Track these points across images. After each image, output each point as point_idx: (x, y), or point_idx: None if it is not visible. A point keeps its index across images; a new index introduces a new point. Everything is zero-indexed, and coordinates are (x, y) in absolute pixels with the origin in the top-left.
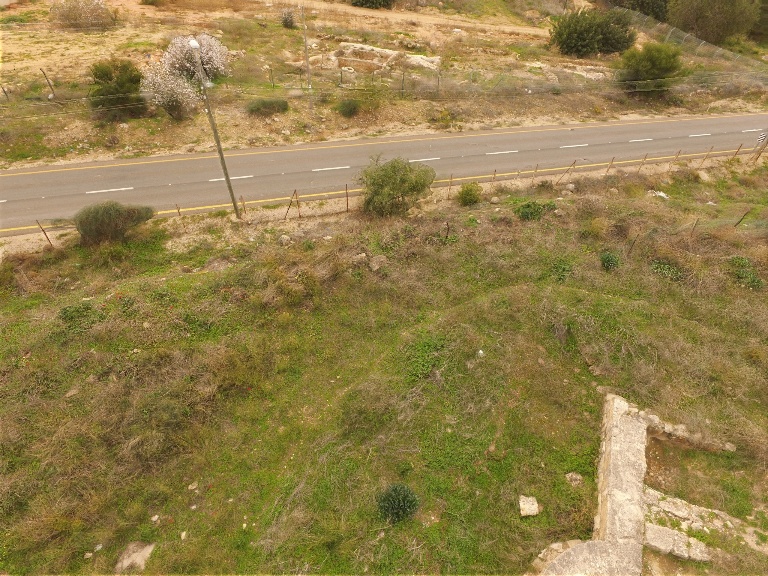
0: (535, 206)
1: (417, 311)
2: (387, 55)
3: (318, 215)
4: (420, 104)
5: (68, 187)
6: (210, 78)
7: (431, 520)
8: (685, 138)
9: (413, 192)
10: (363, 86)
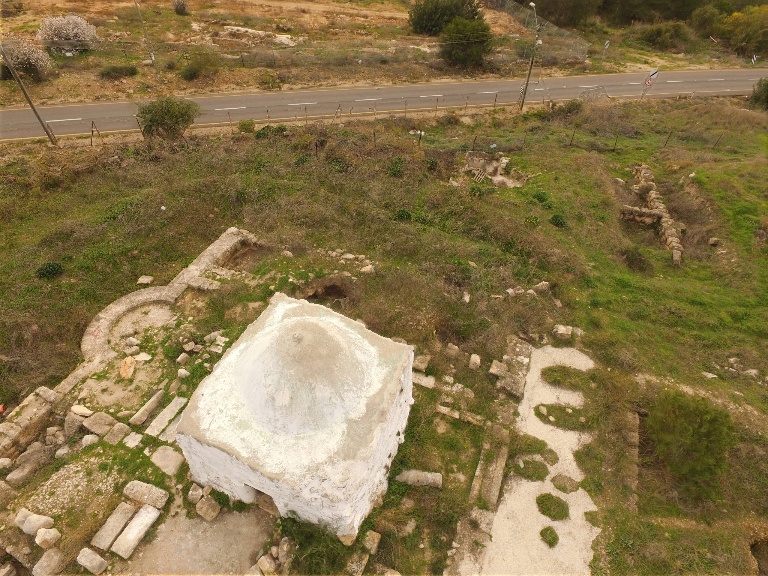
0: (268, 129)
1: None
2: None
3: (120, 143)
4: (256, 70)
5: None
6: (79, 51)
7: (70, 280)
8: (472, 94)
9: (173, 118)
10: (197, 54)
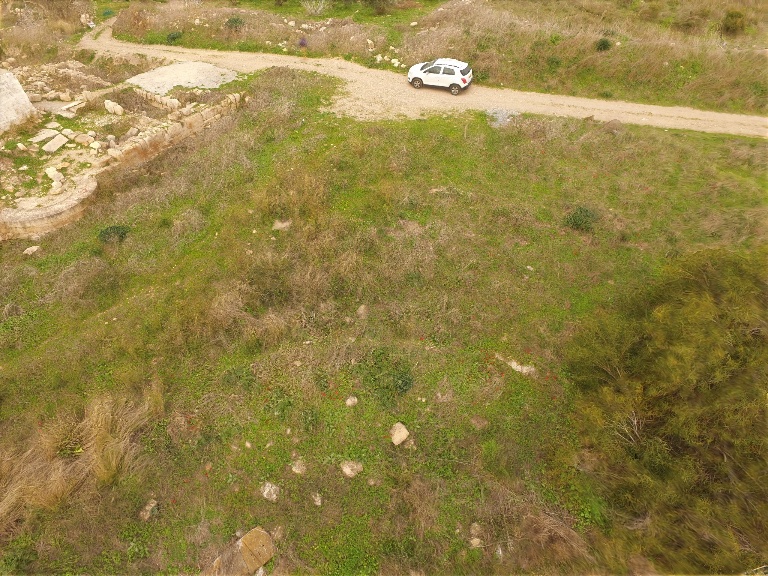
0: None
1: None
2: None
3: None
4: None
5: None
6: None
7: None
8: None
9: None
10: None
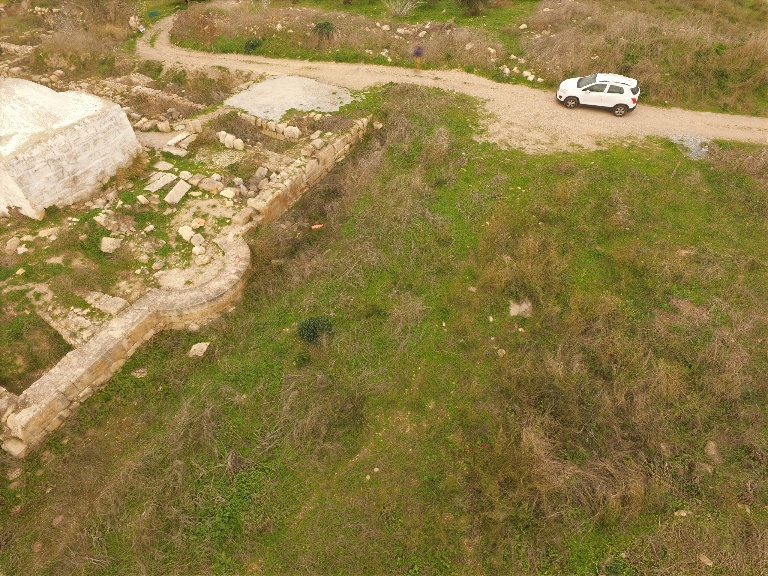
0: None
1: None
2: None
3: None
4: None
5: None
6: None
7: (290, 328)
8: None
9: None
10: None
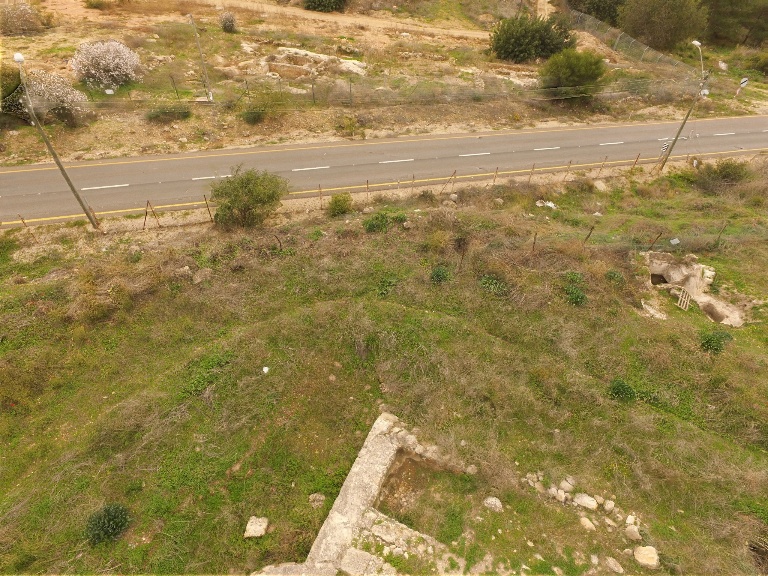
0: (383, 218)
1: (222, 326)
2: (321, 60)
3: (180, 225)
4: (330, 111)
5: None
6: (120, 84)
7: (140, 541)
8: (595, 146)
9: (258, 204)
10: (265, 93)
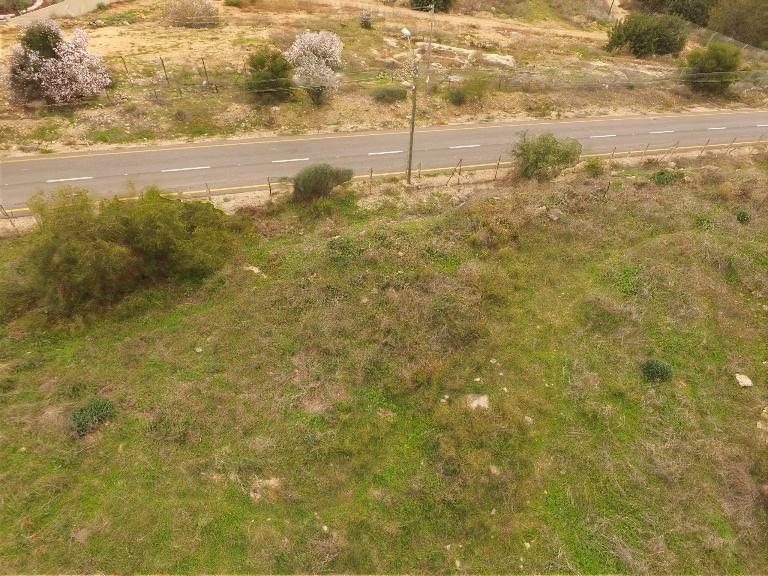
0: (668, 173)
1: (602, 250)
2: (464, 54)
3: (472, 183)
4: (516, 95)
5: (254, 157)
6: None
7: (681, 384)
8: (754, 127)
9: (568, 160)
10: None
